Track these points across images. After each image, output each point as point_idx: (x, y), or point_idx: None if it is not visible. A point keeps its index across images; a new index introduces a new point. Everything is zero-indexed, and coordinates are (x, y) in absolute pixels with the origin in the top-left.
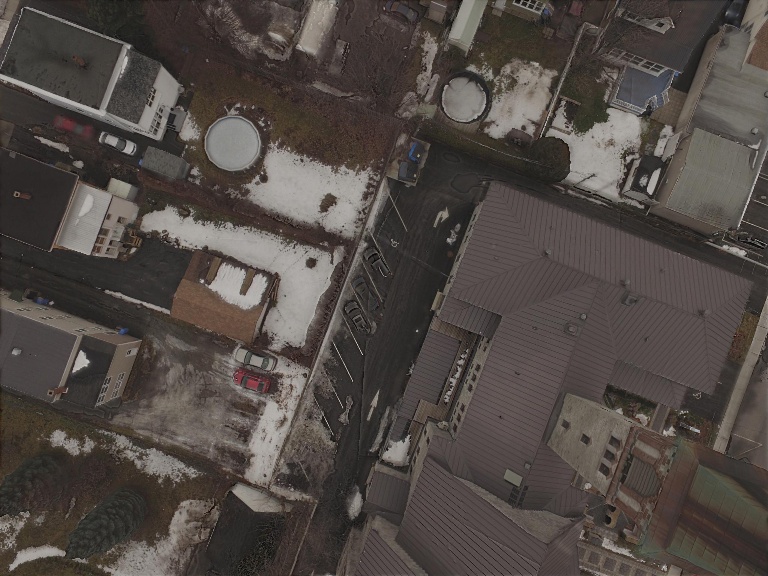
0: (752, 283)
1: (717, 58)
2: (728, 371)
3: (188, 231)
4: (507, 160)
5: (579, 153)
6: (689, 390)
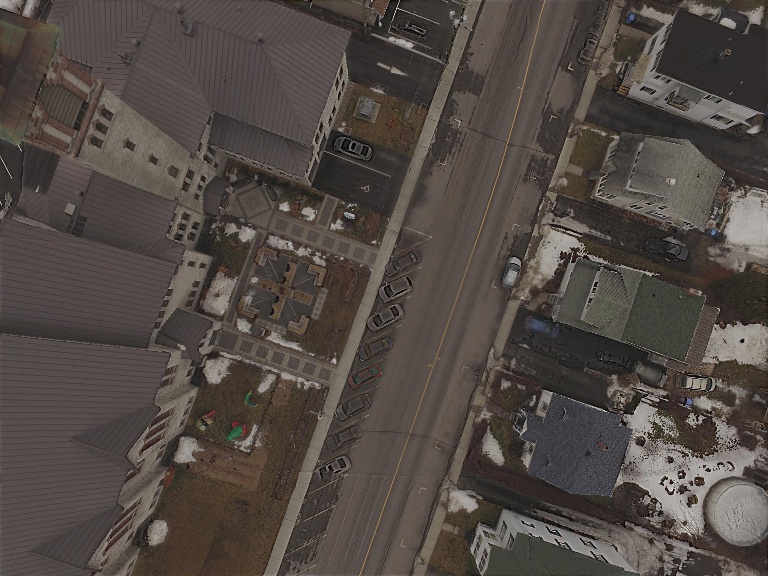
0: (348, 32)
1: None
2: (397, 164)
3: None
4: None
5: None
6: (357, 183)
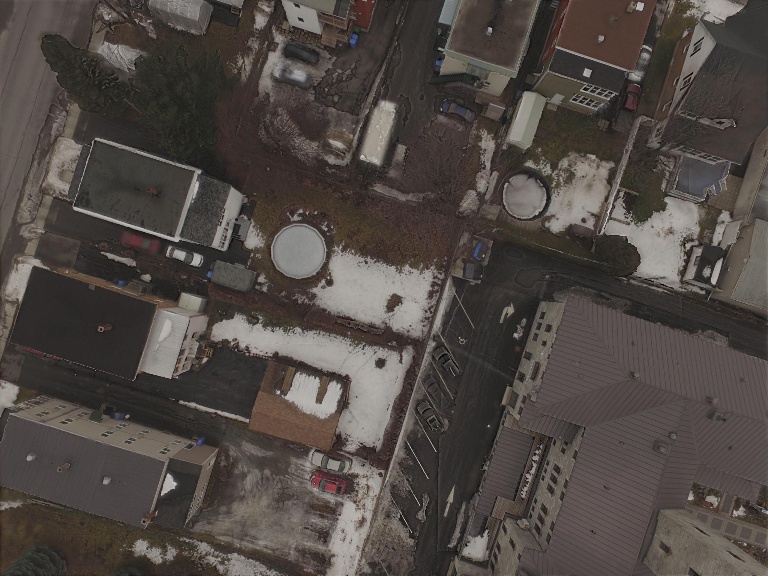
0: None
1: None
2: None
3: (258, 338)
4: (572, 258)
5: (639, 243)
6: None
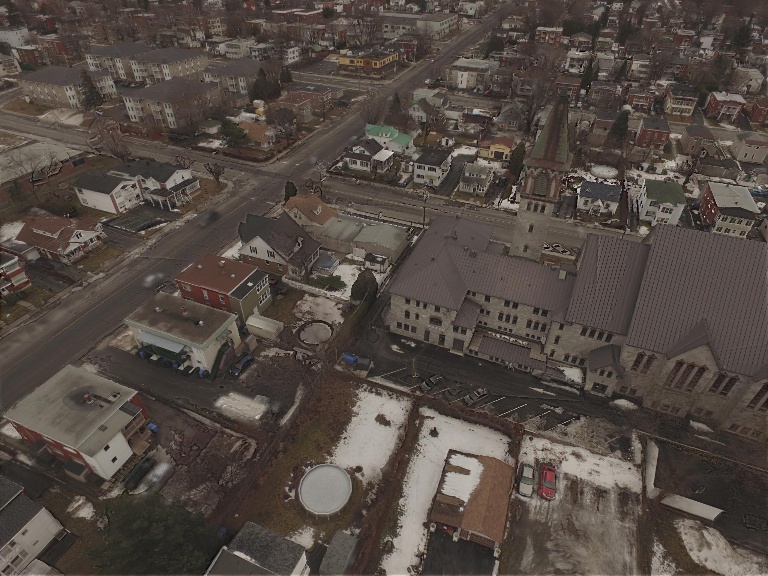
0: None
1: (317, 234)
2: None
3: (408, 542)
4: (362, 309)
5: None
6: None
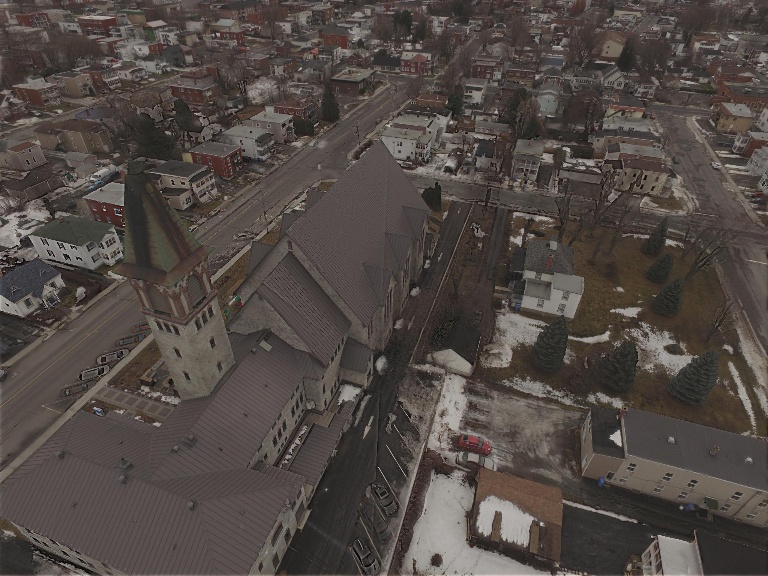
0: None
1: None
2: None
3: None
4: None
5: None
6: None
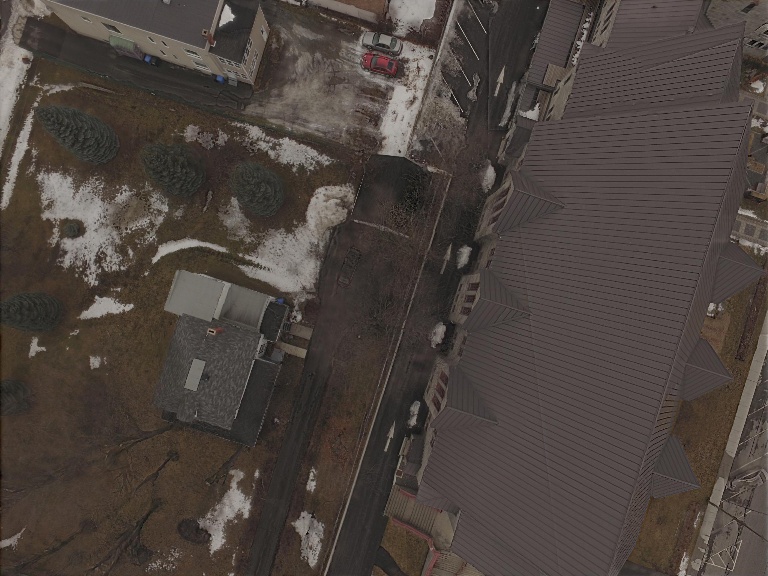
0: None
1: None
2: None
3: None
4: None
5: None
6: None
